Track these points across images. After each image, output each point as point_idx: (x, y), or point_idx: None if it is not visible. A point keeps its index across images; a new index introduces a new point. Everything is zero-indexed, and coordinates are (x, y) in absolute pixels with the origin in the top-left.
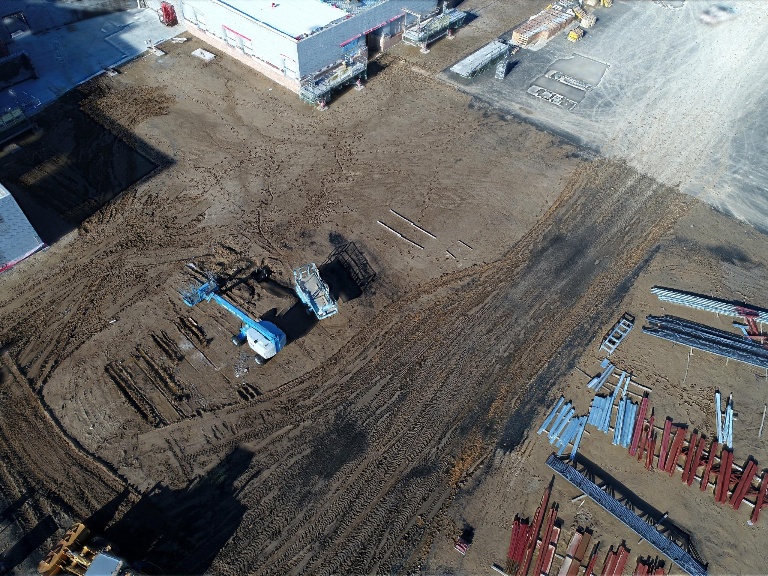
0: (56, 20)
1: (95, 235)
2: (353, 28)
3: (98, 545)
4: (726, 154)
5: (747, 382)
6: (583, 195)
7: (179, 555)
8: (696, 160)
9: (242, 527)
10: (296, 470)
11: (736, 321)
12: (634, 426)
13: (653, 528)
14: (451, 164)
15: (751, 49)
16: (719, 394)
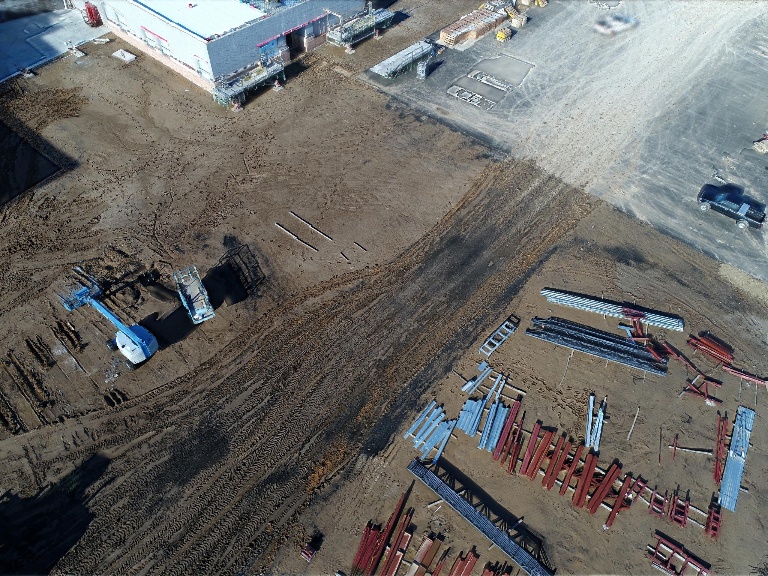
0: None
1: None
2: (270, 28)
3: None
4: (638, 154)
5: (624, 384)
6: (487, 196)
7: (17, 565)
8: (606, 160)
9: (86, 535)
10: (151, 477)
11: (622, 323)
12: (502, 430)
13: (503, 533)
14: (359, 165)
15: (680, 48)
16: (593, 397)
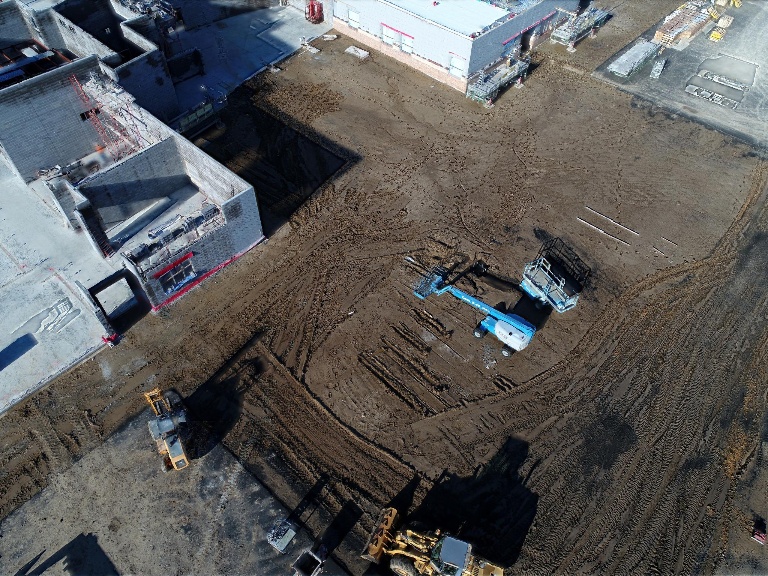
0: (207, 17)
1: (308, 228)
2: (515, 27)
3: (421, 529)
4: None
5: None
6: None
7: (488, 540)
8: None
9: (539, 514)
10: (574, 460)
11: None
12: None
13: None
14: (631, 162)
15: None
16: None
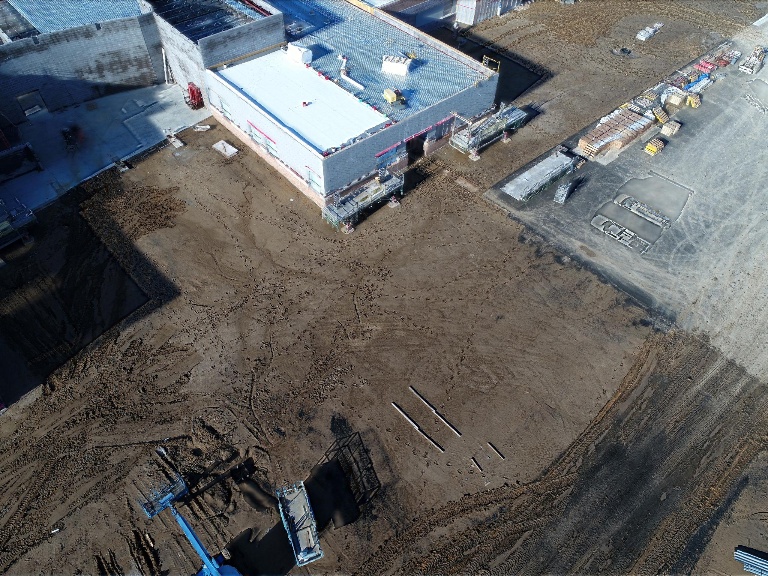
0: (76, 97)
1: (61, 395)
2: (392, 137)
3: None
4: None
5: None
6: (651, 385)
7: None
8: None
9: None
10: None
11: None
12: None
13: None
14: (490, 323)
15: None
16: None
